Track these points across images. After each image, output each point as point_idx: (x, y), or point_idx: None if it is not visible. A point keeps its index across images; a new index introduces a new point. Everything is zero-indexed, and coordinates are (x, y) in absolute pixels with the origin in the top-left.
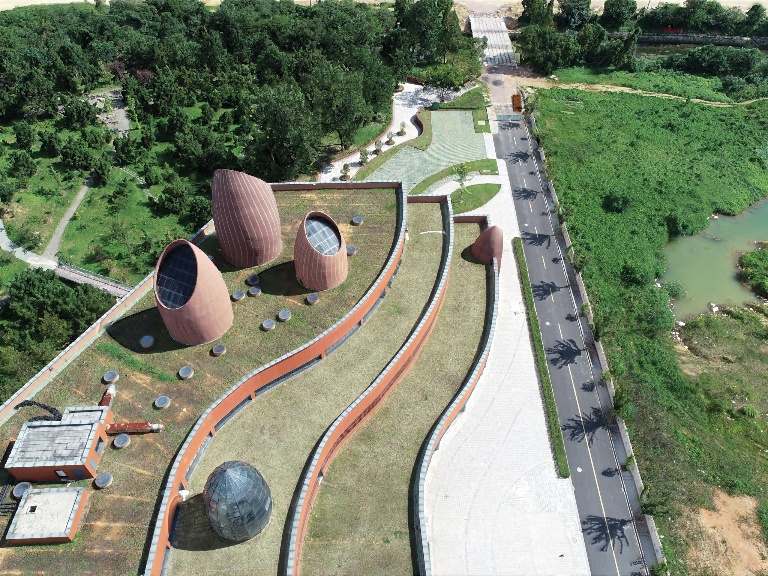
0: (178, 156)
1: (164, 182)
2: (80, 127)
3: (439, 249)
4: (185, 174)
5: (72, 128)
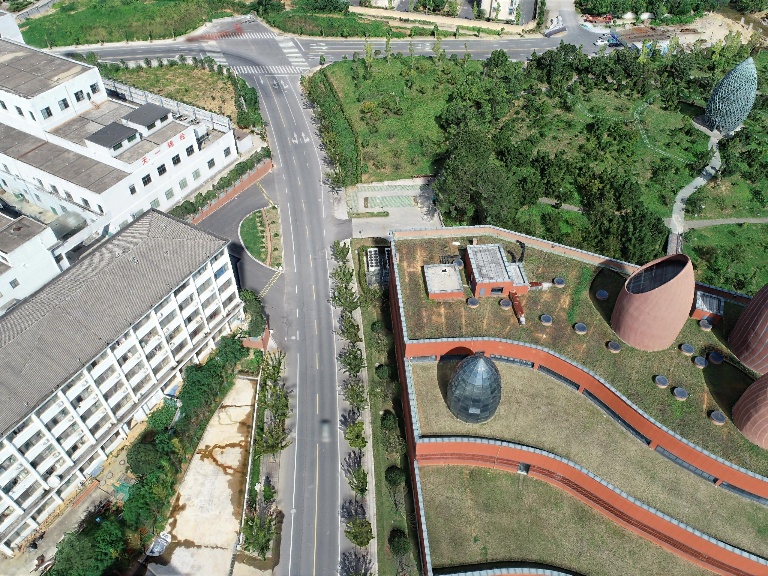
0: None
1: None
2: None
3: None
4: None
5: None
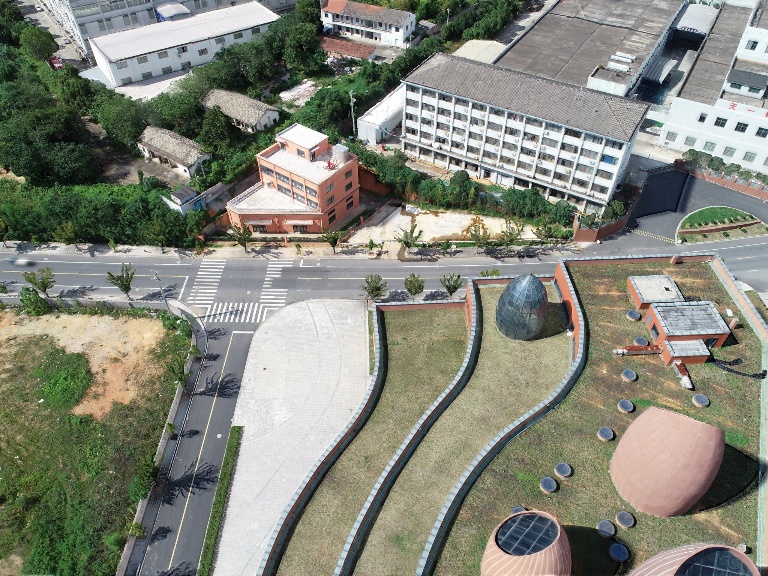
0: None
1: None
2: None
3: None
4: None
5: None
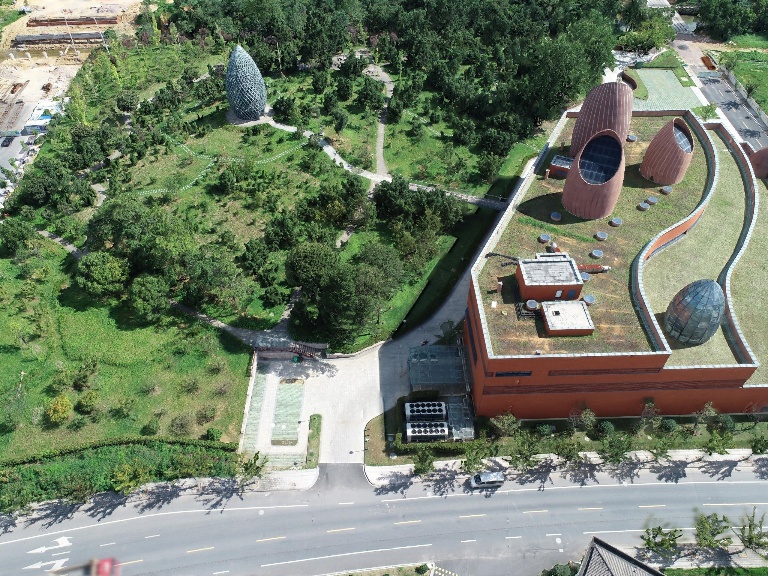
0: (442, 102)
1: (442, 121)
2: (354, 78)
3: (733, 162)
4: None
5: None
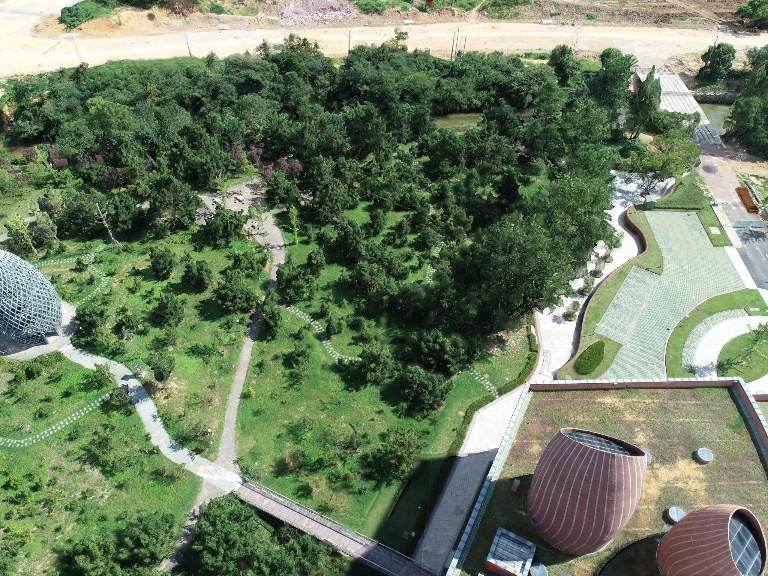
0: (354, 286)
1: (347, 329)
2: (225, 244)
3: None
4: (369, 314)
5: (214, 244)
